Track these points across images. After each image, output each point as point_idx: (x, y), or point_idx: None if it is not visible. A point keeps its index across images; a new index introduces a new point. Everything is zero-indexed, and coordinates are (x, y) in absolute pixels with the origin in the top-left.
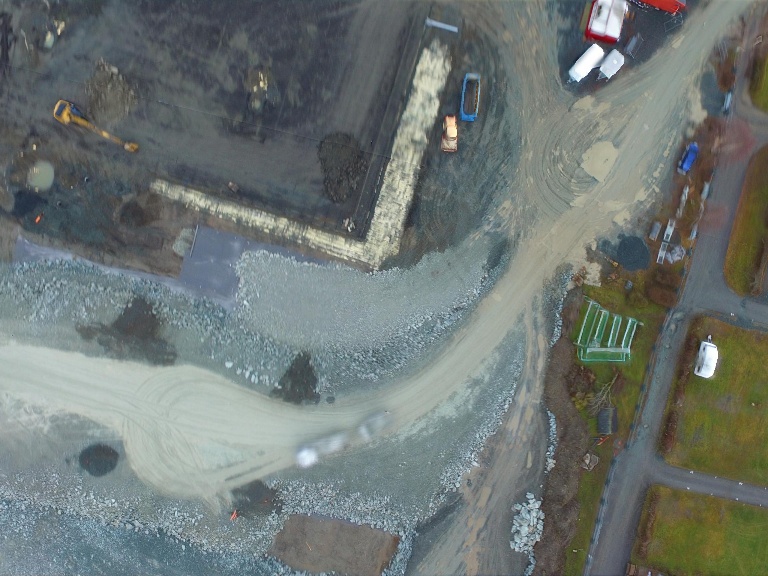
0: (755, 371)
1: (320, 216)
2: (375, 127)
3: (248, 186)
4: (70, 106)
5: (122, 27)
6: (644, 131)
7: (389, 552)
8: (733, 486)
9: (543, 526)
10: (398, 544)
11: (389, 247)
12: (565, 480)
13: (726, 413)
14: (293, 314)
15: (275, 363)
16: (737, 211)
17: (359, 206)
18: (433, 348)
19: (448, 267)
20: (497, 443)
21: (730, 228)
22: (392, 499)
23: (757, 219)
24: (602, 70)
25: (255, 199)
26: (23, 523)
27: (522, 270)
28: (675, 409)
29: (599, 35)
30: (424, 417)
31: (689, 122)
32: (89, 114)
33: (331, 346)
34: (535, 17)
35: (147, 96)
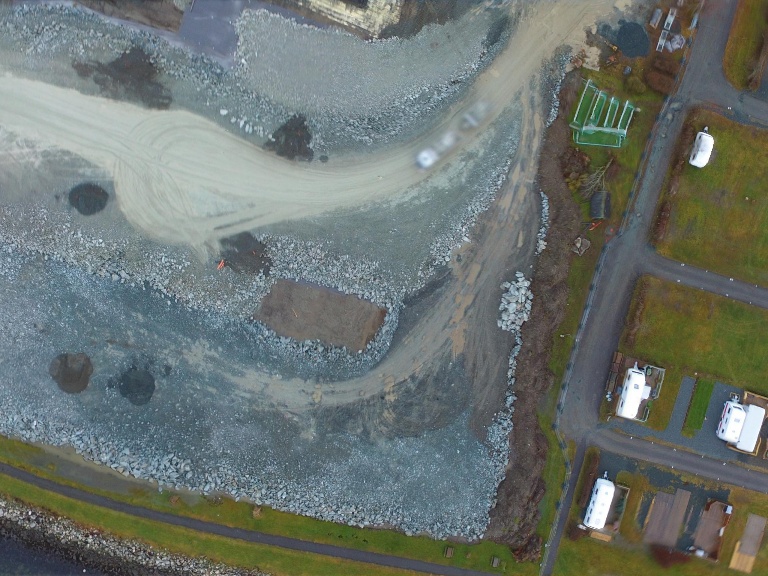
0: (750, 167)
1: None
2: None
3: None
4: None
5: None
6: None
7: (375, 324)
8: (724, 281)
9: (531, 306)
10: (385, 316)
11: (389, 16)
12: (555, 261)
13: (719, 207)
14: (290, 76)
15: (270, 118)
16: (738, 5)
17: None
18: (429, 118)
19: (447, 40)
20: (489, 220)
21: (731, 21)
22: (381, 264)
23: (758, 14)
24: None
25: None
26: (9, 266)
27: (521, 48)
28: (669, 199)
29: None
30: (417, 186)
31: None
32: None
33: (327, 111)
34: None
35: None
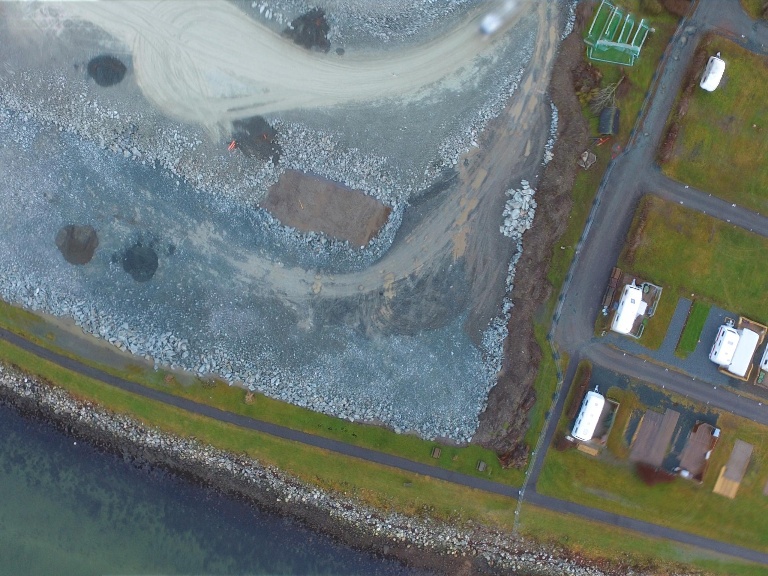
0: (760, 95)
1: None
2: None
3: None
4: None
5: None
6: None
7: (379, 222)
8: (726, 207)
9: (534, 214)
10: (389, 214)
11: None
12: (561, 172)
13: (727, 133)
14: None
15: (290, 8)
16: None
17: None
18: (446, 22)
19: None
20: (498, 127)
21: None
22: (389, 160)
23: None
24: None
25: None
26: (24, 134)
27: None
28: (677, 120)
29: None
30: (429, 86)
31: None
32: None
33: (346, 7)
34: None
35: None
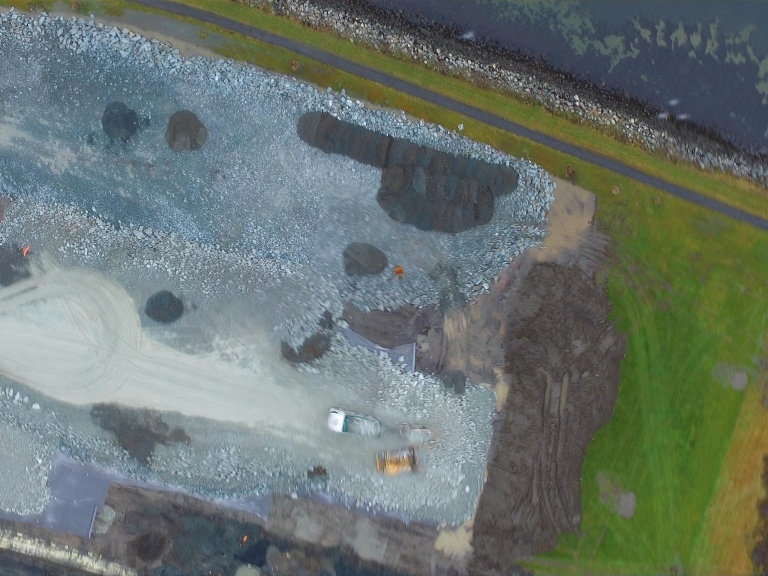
0: None
1: None
2: None
3: None
4: None
5: None
6: None
7: None
8: None
9: None
10: None
11: None
12: None
13: None
14: None
15: None
16: None
17: None
18: None
19: None
20: None
21: None
22: None
23: None
24: None
25: (32, 567)
26: (254, 235)
27: None
28: None
29: None
30: None
31: None
32: None
33: None
34: None
35: None
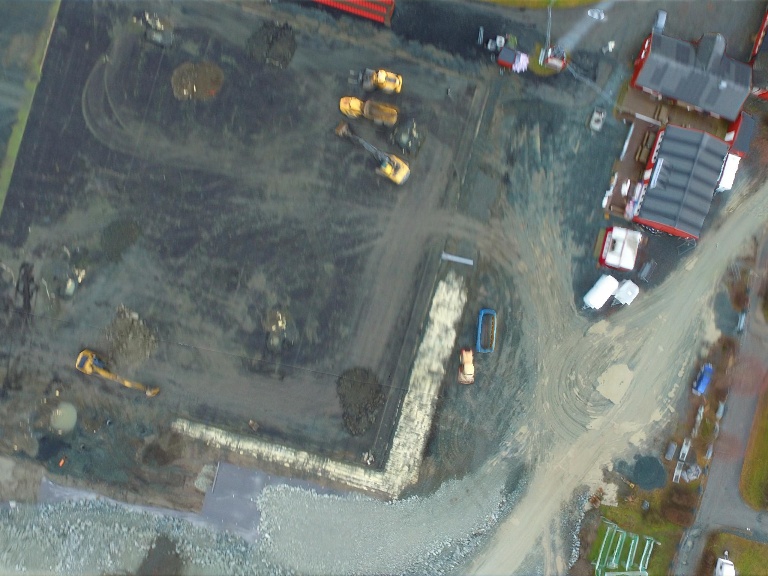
0: None
1: (339, 449)
2: (393, 361)
3: (268, 423)
4: (92, 358)
5: (142, 273)
6: (659, 353)
7: None
8: None
9: None
10: None
11: (408, 476)
12: None
13: None
14: (314, 545)
15: None
16: (752, 428)
17: (378, 438)
18: (453, 575)
19: (466, 494)
20: None
21: (745, 445)
22: None
23: None
24: (616, 297)
25: (275, 435)
26: None
27: (540, 494)
28: None
29: (613, 266)
30: None
31: (703, 342)
32: (111, 360)
33: (352, 575)
34: (549, 246)
35: (167, 339)
